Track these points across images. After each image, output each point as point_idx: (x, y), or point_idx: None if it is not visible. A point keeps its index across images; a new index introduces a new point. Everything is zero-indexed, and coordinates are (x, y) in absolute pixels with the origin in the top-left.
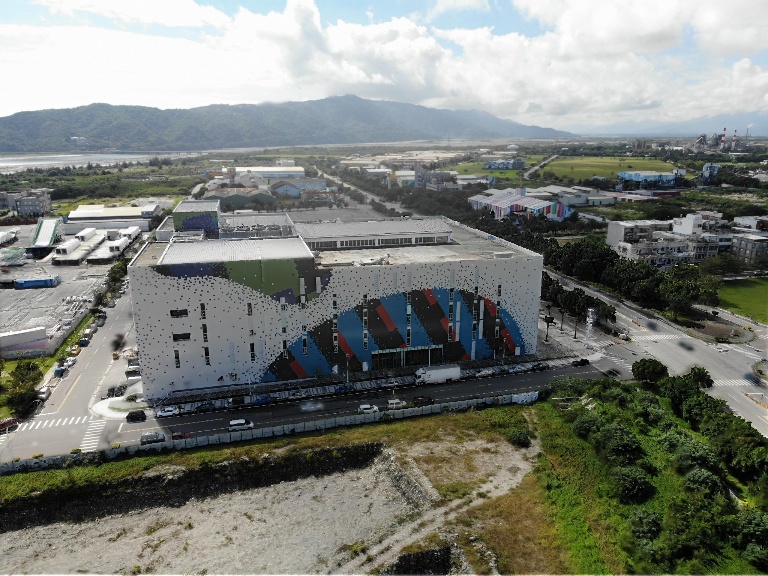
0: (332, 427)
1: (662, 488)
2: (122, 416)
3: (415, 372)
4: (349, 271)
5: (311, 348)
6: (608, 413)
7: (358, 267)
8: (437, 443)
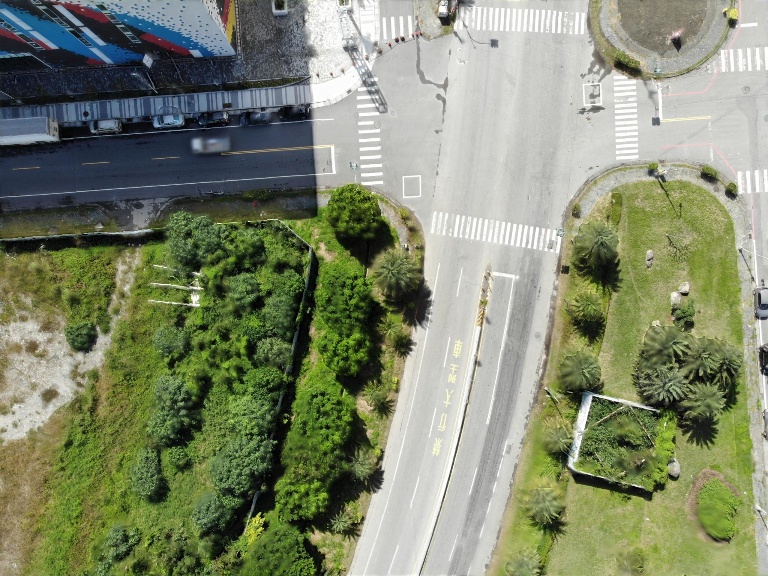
0: None
1: (174, 494)
2: None
3: None
4: None
5: None
6: None
7: None
8: None
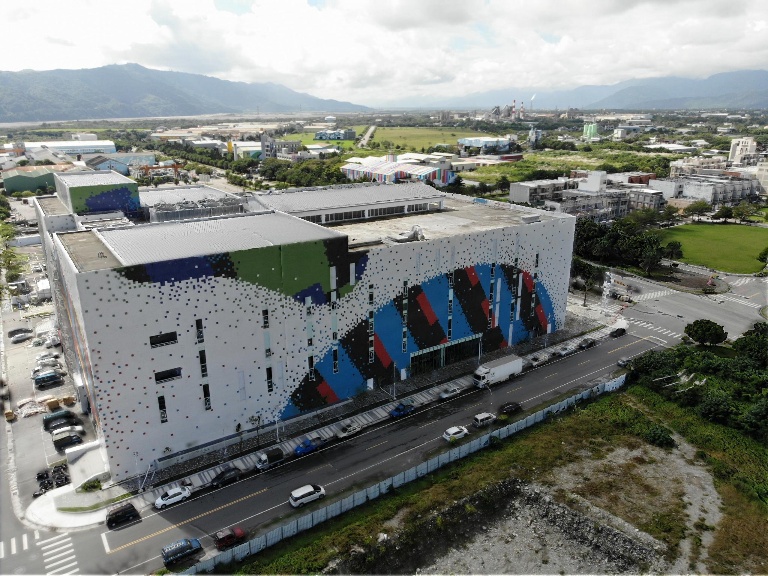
0: (436, 469)
1: None
2: (93, 520)
3: (474, 372)
4: (388, 251)
5: (343, 361)
6: (730, 389)
7: (398, 245)
8: (578, 464)
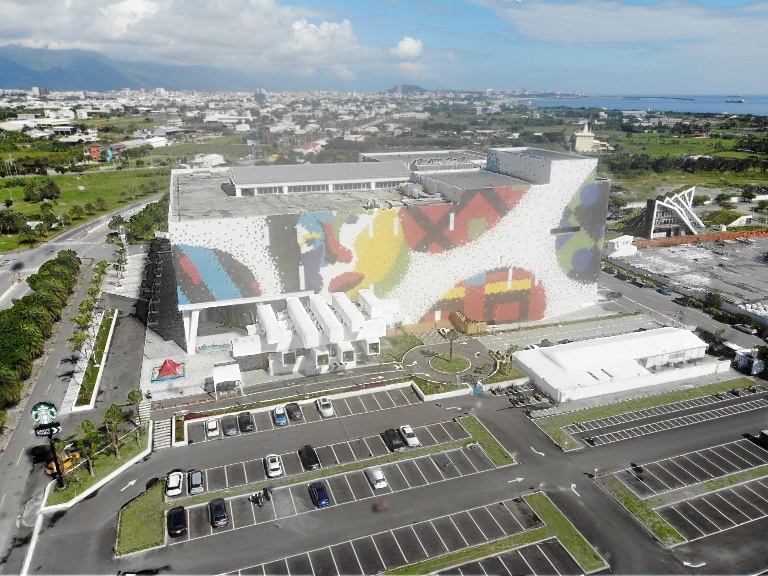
0: None
1: None
2: None
3: None
4: None
5: None
6: None
7: None
8: None
